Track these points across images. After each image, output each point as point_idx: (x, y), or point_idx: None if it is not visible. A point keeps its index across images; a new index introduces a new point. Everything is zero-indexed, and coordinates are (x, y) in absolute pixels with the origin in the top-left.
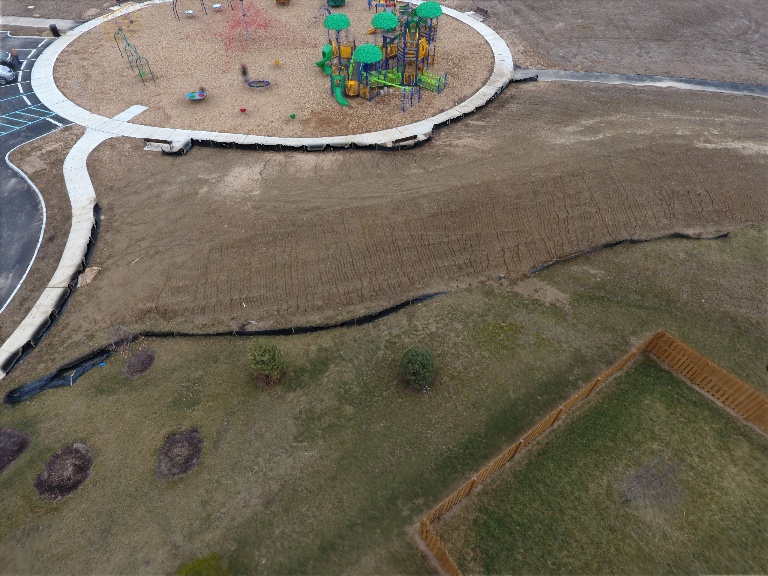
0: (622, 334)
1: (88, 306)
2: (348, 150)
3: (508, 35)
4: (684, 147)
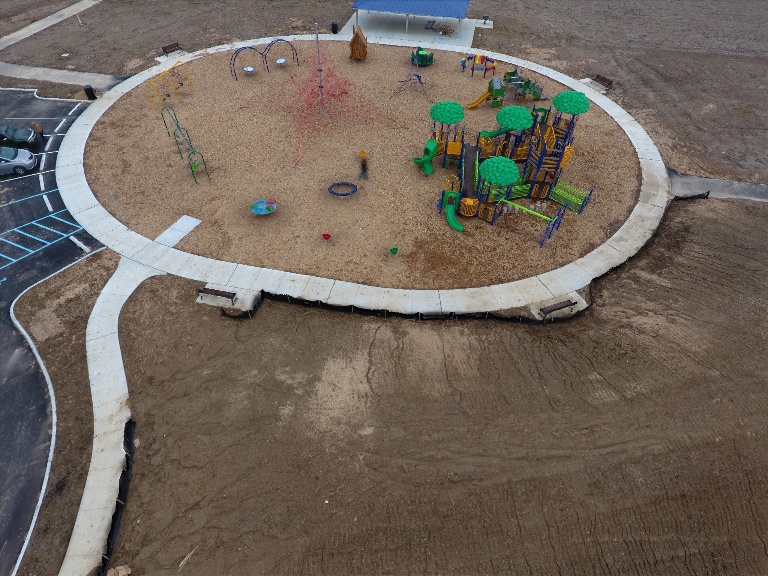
0: None
1: None
2: (480, 321)
3: (645, 118)
4: None
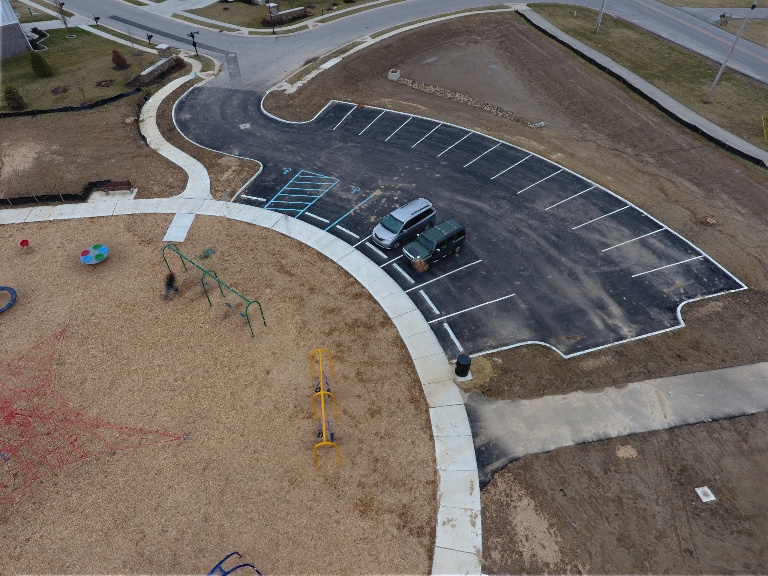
0: None
1: (124, 112)
2: None
3: None
4: None
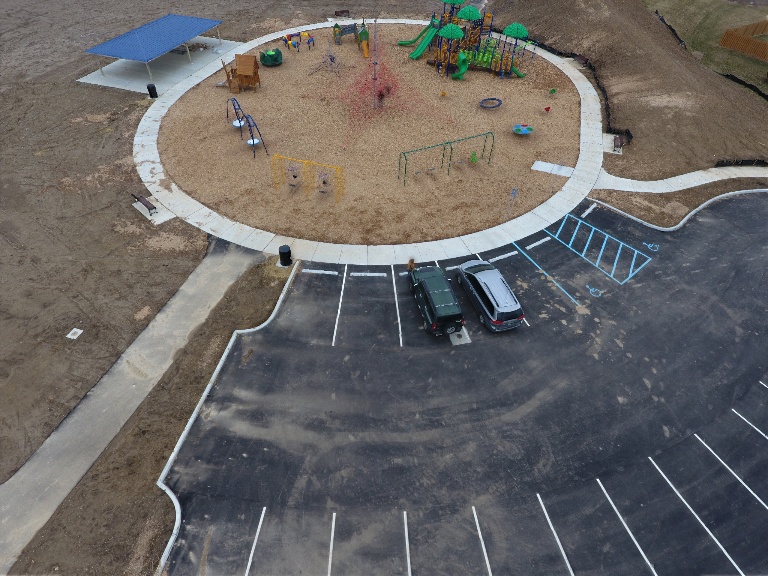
0: None
1: None
2: None
3: (392, 16)
4: None
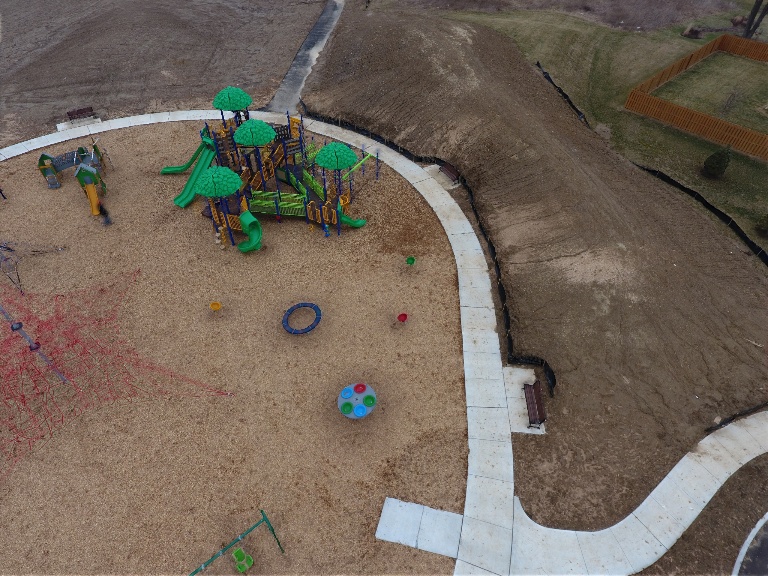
0: (617, 112)
1: None
2: (476, 210)
3: (167, 106)
4: (474, 47)
